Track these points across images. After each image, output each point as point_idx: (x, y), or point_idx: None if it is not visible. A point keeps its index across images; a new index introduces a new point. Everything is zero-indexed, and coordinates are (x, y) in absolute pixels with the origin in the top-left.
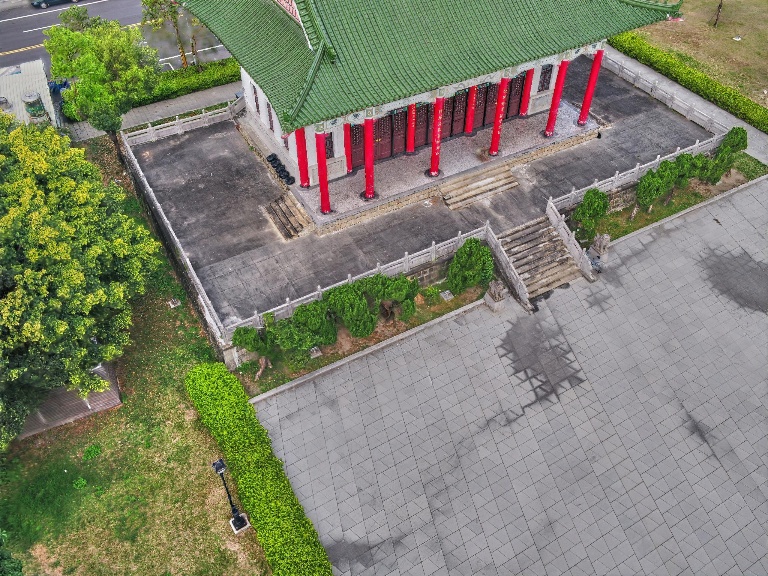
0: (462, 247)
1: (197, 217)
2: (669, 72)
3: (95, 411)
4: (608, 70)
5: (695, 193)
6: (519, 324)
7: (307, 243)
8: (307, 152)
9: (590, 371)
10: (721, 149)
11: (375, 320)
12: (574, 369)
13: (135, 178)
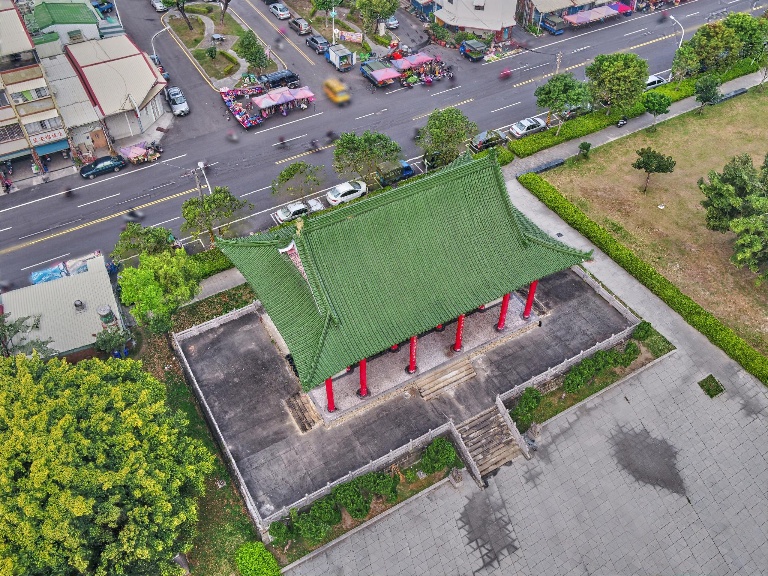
0: (431, 446)
1: (235, 411)
2: (602, 247)
3: None
4: None
5: (612, 373)
6: (474, 499)
7: (318, 435)
8: None
9: (523, 540)
10: (629, 344)
11: (369, 507)
12: (512, 539)
13: (185, 373)
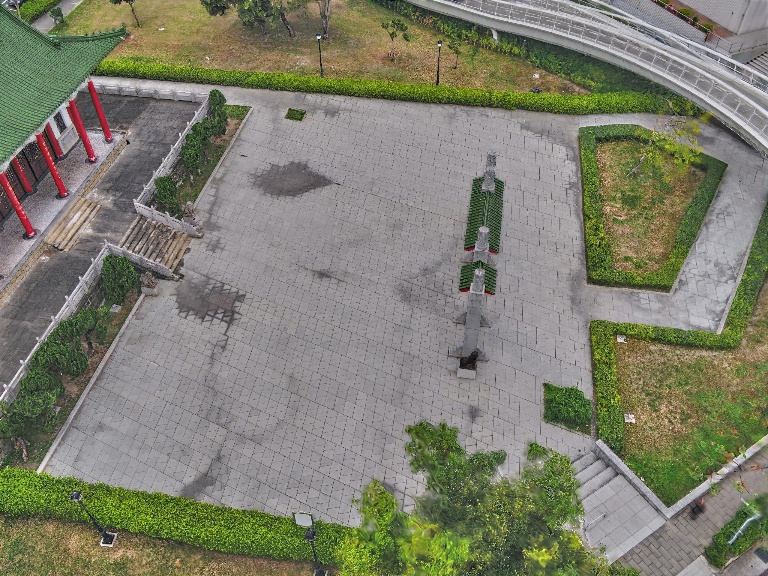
0: (104, 267)
1: None
2: (136, 74)
3: None
4: None
5: (218, 146)
6: (179, 292)
7: None
8: None
9: (244, 287)
10: (213, 109)
11: (84, 353)
12: (235, 292)
13: None
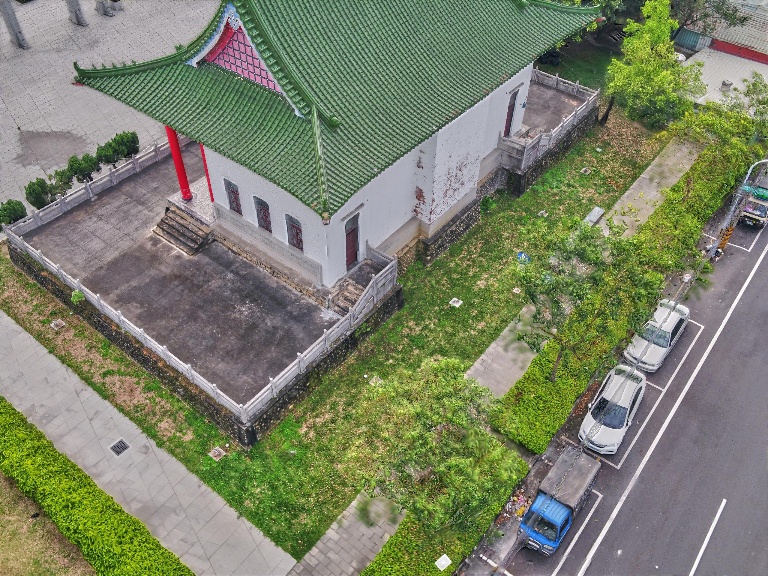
0: None
1: None
2: None
3: None
4: None
5: None
6: None
7: None
8: None
9: None
10: None
11: None
12: None
13: None
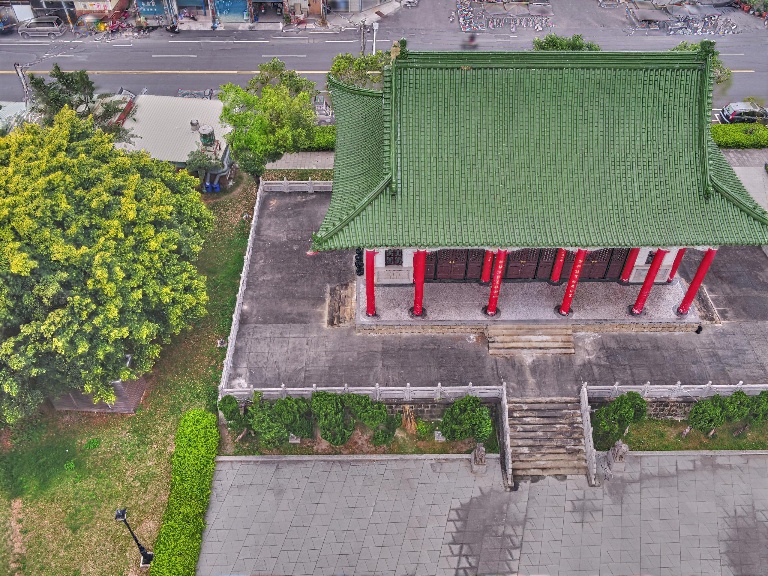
0: (459, 400)
1: (274, 276)
2: None
3: (113, 411)
4: (766, 257)
5: None
6: (488, 496)
7: (342, 336)
8: (375, 255)
9: None
10: None
11: (347, 435)
12: (510, 568)
13: None
